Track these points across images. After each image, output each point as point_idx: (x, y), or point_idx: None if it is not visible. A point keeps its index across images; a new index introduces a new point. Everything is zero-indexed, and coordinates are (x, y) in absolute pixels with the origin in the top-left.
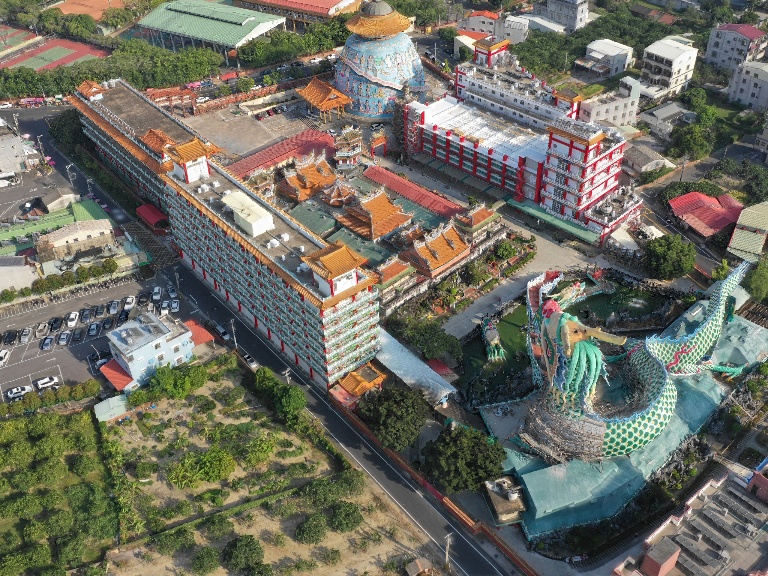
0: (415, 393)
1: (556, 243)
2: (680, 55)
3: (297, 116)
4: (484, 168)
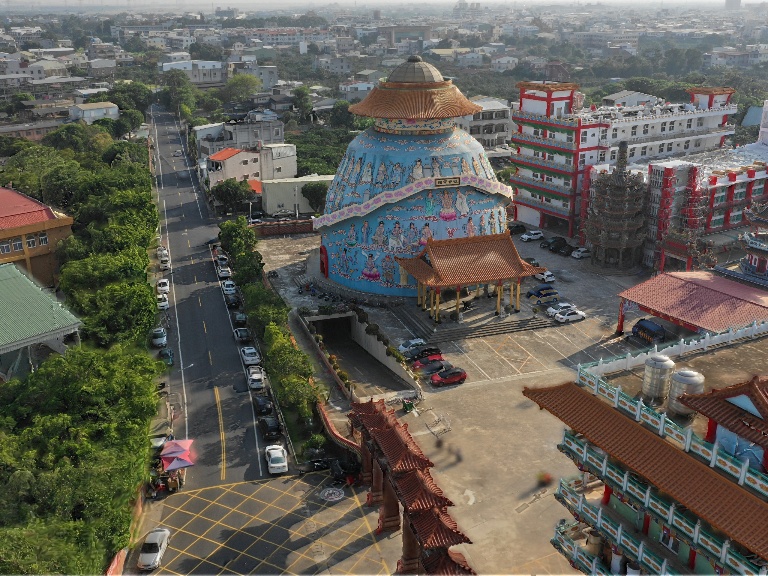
0: None
1: None
2: None
3: (460, 338)
4: None
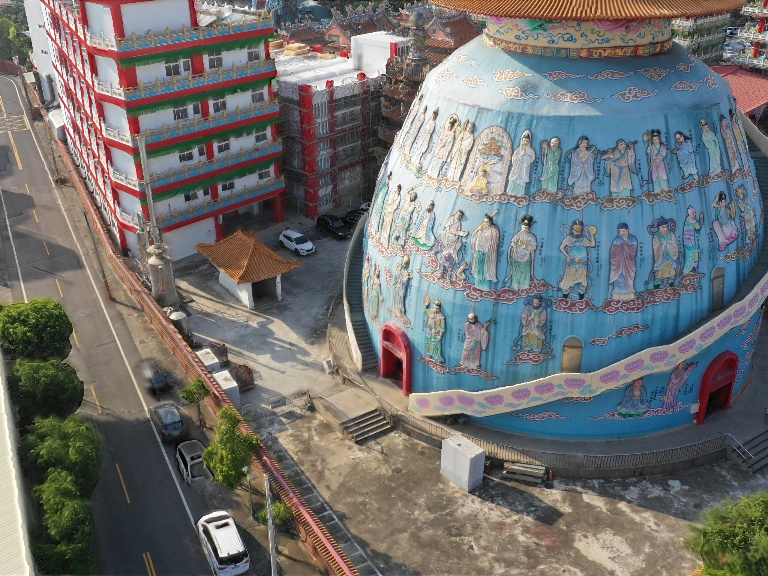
0: None
1: None
2: None
3: None
4: None
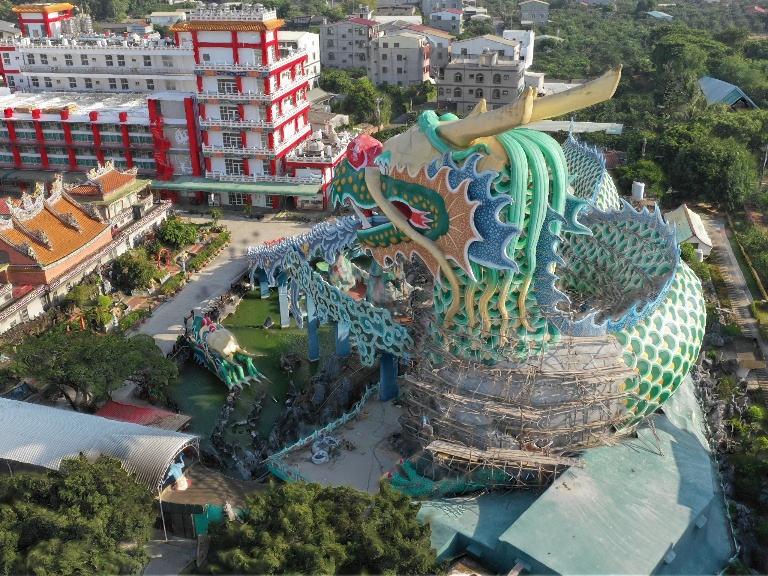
0: (91, 466)
1: (253, 220)
2: (303, 35)
3: None
4: (89, 152)
